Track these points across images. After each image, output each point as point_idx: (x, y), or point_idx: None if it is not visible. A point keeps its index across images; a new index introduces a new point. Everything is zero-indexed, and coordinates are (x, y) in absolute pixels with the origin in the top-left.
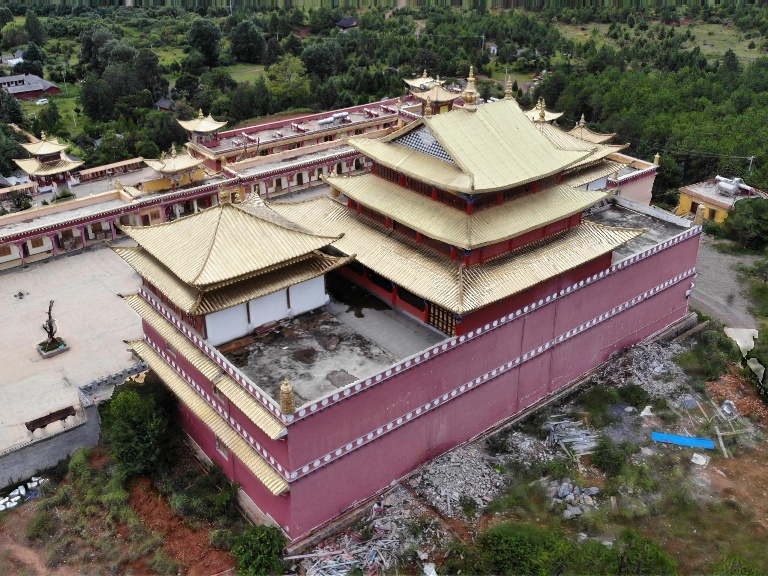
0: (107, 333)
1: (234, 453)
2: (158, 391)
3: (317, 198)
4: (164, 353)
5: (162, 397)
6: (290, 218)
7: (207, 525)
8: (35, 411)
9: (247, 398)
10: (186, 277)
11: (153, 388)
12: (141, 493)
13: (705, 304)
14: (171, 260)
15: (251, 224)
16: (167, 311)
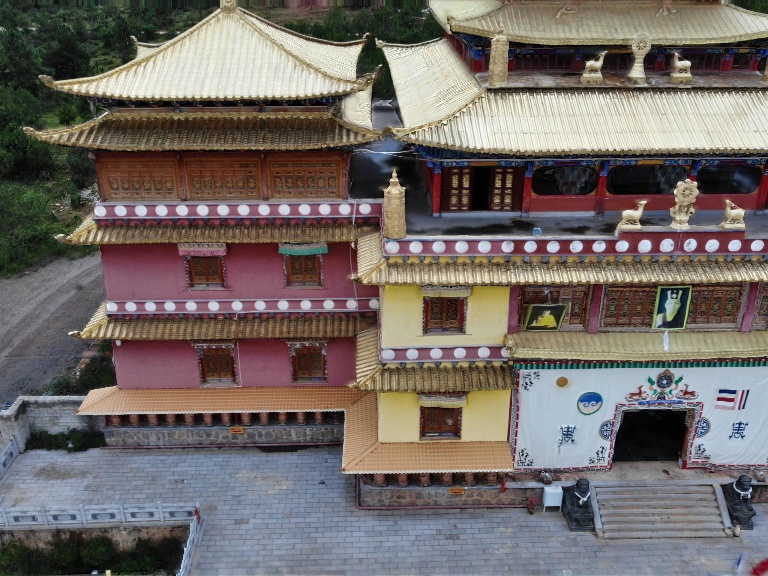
0: None
1: None
2: None
3: None
4: None
5: None
6: None
7: None
8: None
9: None
10: None
11: None
12: None
13: (94, 280)
14: None
15: None
16: None
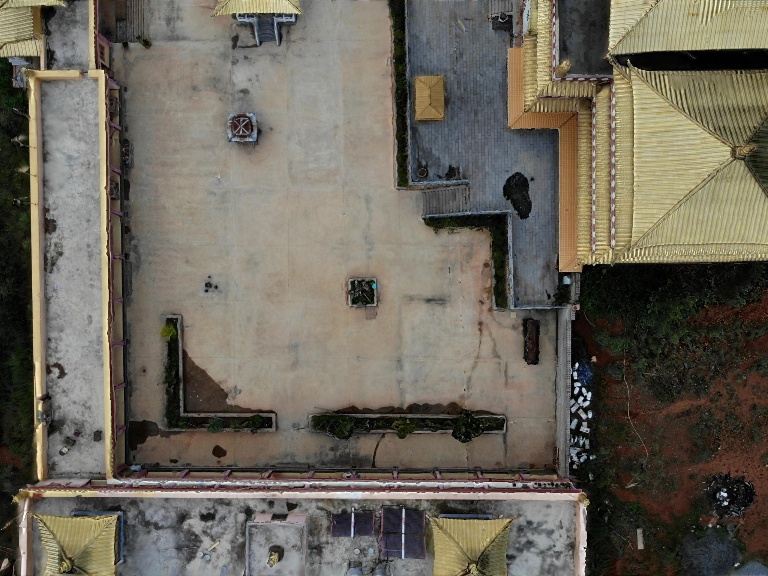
0: (368, 233)
1: None
2: (638, 265)
3: (662, 1)
4: None
5: None
6: (652, 47)
7: (759, 289)
8: (466, 342)
9: None
10: None
11: (634, 267)
12: None
13: None
14: (739, 237)
15: (762, 140)
16: None
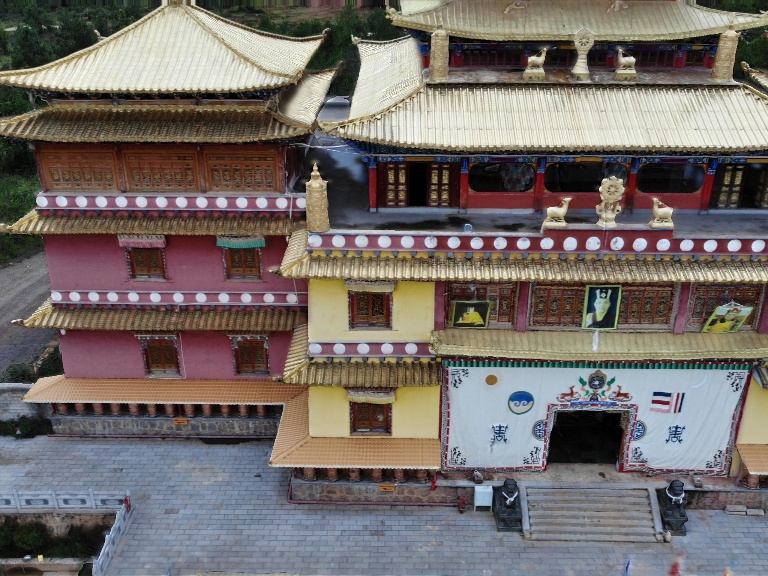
0: None
1: None
2: None
3: (758, 92)
4: None
5: None
6: None
7: None
8: None
9: None
10: None
11: None
12: None
13: None
14: None
15: None
16: None
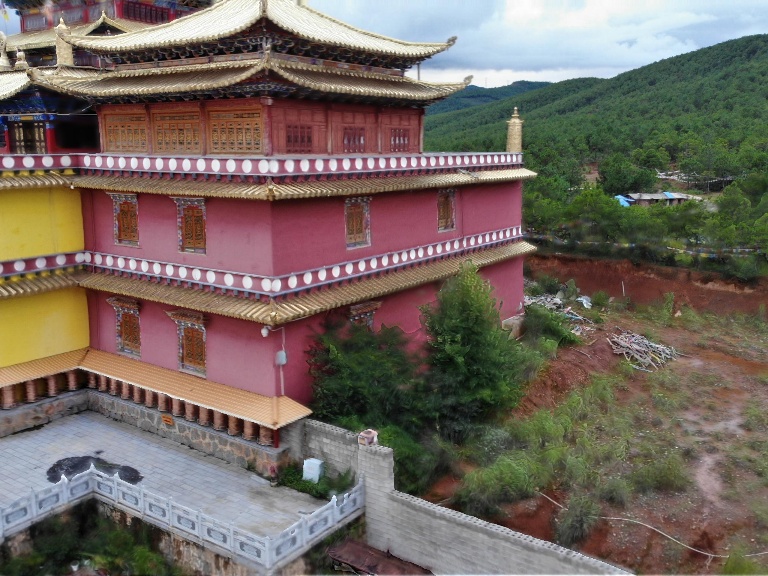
0: None
1: (498, 259)
2: None
3: (59, 69)
4: (340, 265)
5: (386, 328)
6: None
7: None
8: None
9: (493, 171)
10: (418, 49)
11: (366, 336)
12: (518, 415)
13: None
14: (371, 43)
15: None
16: (355, 157)
